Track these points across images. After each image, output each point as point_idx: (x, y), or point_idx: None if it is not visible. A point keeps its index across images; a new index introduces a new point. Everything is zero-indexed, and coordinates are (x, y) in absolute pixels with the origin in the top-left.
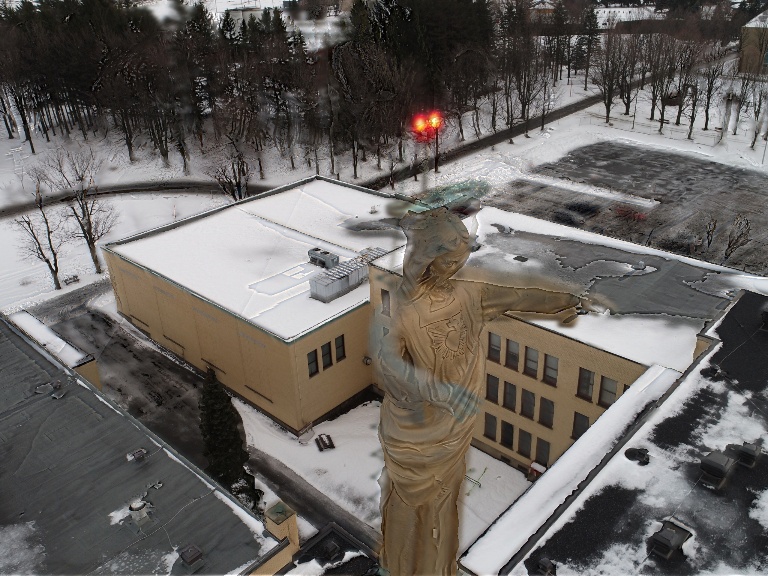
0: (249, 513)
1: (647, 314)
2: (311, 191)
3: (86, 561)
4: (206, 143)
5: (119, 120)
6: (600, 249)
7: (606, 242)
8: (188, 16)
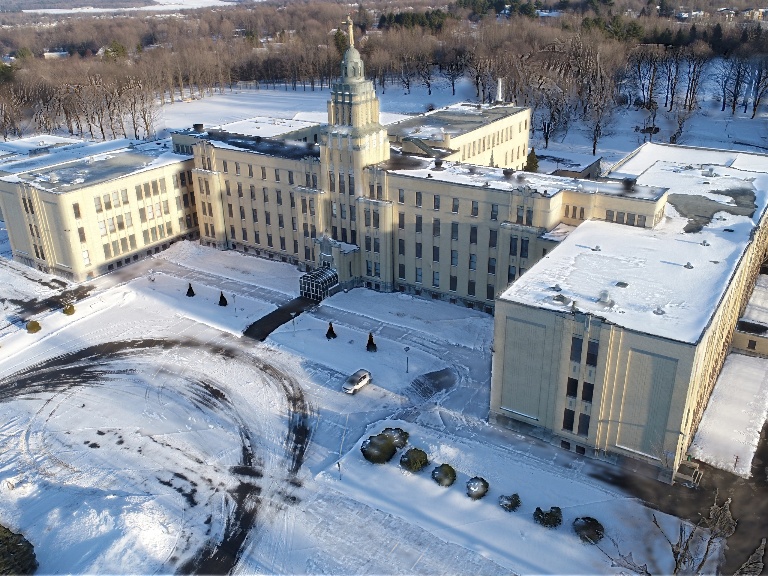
0: (451, 138)
1: (668, 202)
2: None
3: None
4: None
5: None
6: None
7: (762, 197)
8: None
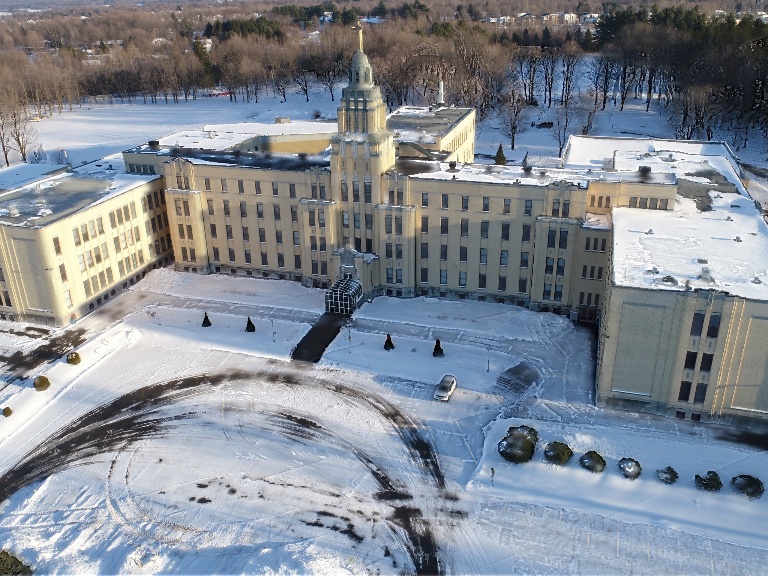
0: None
1: None
2: (708, 147)
3: (410, 136)
4: (734, 125)
5: (682, 96)
6: (719, 176)
7: (730, 176)
8: (761, 36)
